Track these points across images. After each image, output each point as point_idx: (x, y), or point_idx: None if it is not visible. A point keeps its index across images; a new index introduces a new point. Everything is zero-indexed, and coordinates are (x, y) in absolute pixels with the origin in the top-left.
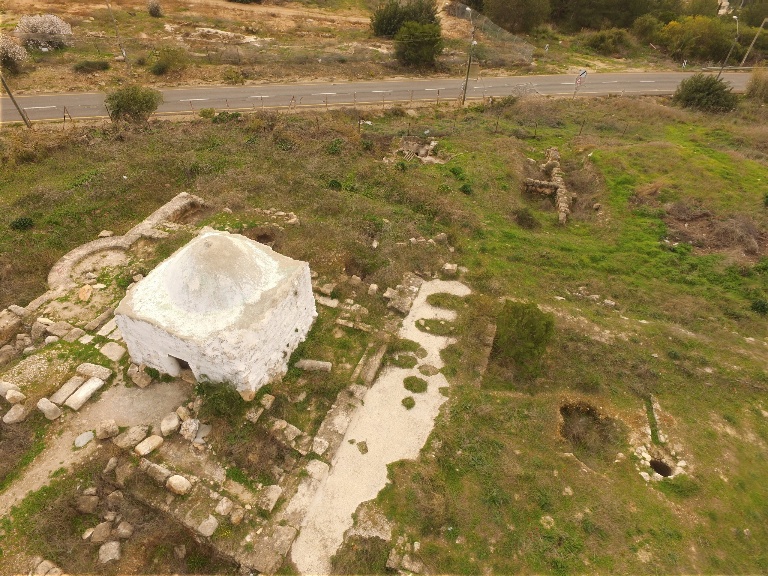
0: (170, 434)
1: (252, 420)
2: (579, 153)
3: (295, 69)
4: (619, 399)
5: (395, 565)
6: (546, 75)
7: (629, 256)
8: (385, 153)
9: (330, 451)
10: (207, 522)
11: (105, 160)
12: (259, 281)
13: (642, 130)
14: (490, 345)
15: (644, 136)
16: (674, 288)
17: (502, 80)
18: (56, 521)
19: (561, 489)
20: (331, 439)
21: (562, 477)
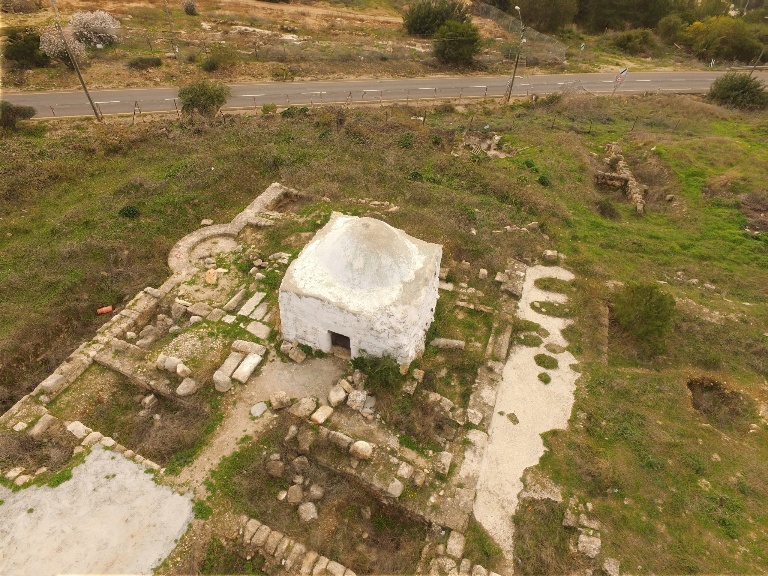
0: (337, 405)
1: (410, 392)
2: (639, 147)
3: (339, 66)
4: (740, 375)
5: (573, 523)
6: (581, 74)
7: (716, 244)
8: (452, 147)
9: (486, 421)
10: (395, 484)
11: (189, 152)
12: (410, 261)
13: (690, 126)
14: (606, 325)
15: (693, 132)
16: (767, 273)
17: (540, 78)
18: (256, 483)
19: (709, 455)
20: (483, 410)
21: (707, 445)
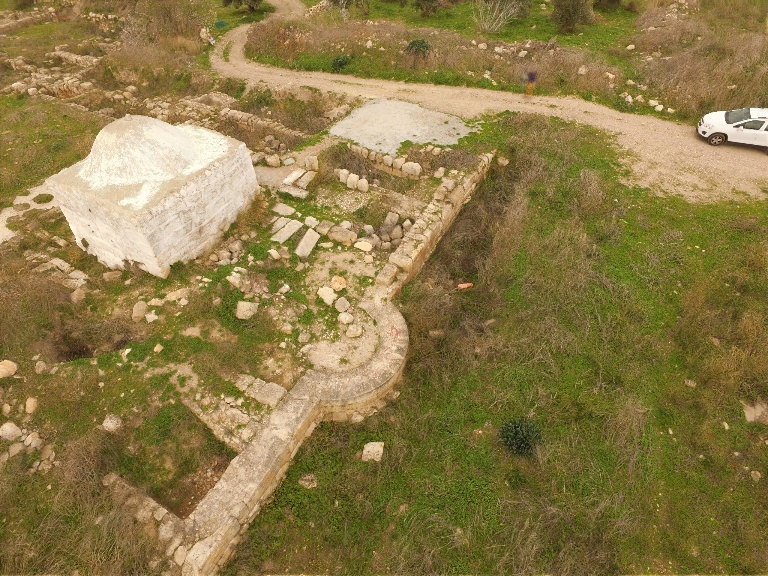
0: None
1: None
2: None
3: None
4: None
5: None
6: None
7: None
8: None
9: None
10: None
11: None
12: None
13: None
14: None
15: None
16: None
17: None
18: None
19: None
20: None
21: (5, 153)
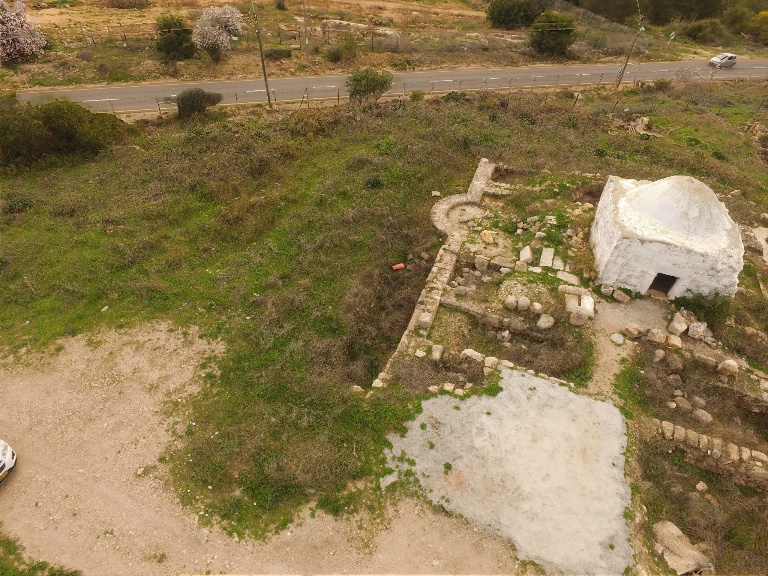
0: (680, 335)
1: (733, 326)
2: None
3: (448, 57)
4: None
5: None
6: (669, 62)
7: None
8: None
9: None
10: (766, 394)
11: (383, 133)
12: None
13: None
14: None
15: None
16: None
17: (634, 66)
18: None
19: None
20: None
21: None
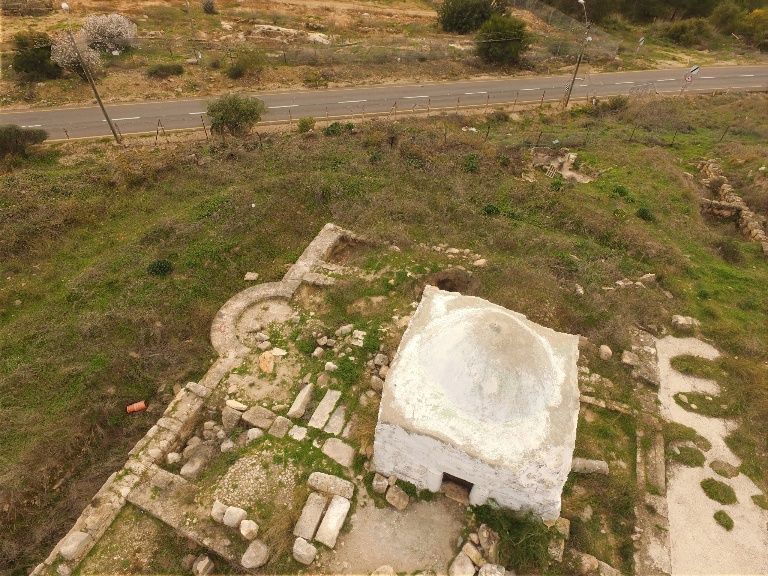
0: None
1: (559, 559)
2: (739, 165)
3: (375, 69)
4: None
5: None
6: (638, 71)
7: None
8: (521, 168)
9: None
10: None
11: (223, 183)
12: (552, 372)
13: None
14: None
15: None
16: None
17: (595, 77)
18: None
19: None
20: None
21: None
